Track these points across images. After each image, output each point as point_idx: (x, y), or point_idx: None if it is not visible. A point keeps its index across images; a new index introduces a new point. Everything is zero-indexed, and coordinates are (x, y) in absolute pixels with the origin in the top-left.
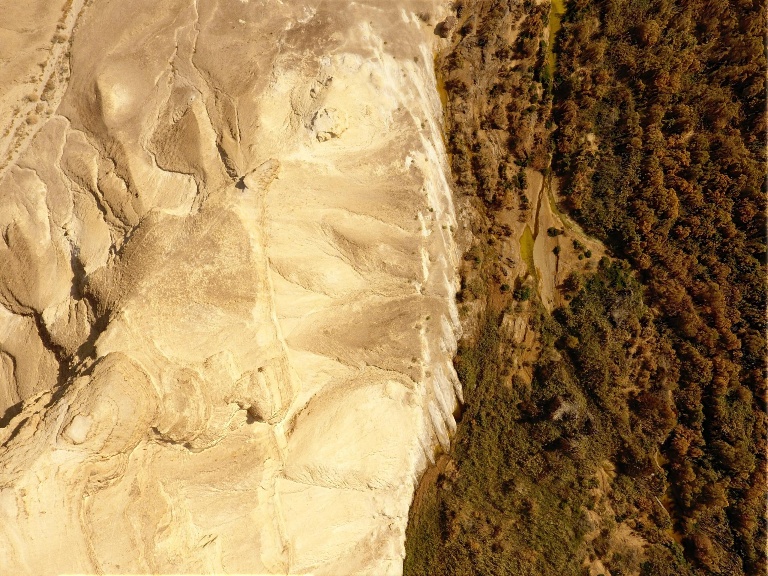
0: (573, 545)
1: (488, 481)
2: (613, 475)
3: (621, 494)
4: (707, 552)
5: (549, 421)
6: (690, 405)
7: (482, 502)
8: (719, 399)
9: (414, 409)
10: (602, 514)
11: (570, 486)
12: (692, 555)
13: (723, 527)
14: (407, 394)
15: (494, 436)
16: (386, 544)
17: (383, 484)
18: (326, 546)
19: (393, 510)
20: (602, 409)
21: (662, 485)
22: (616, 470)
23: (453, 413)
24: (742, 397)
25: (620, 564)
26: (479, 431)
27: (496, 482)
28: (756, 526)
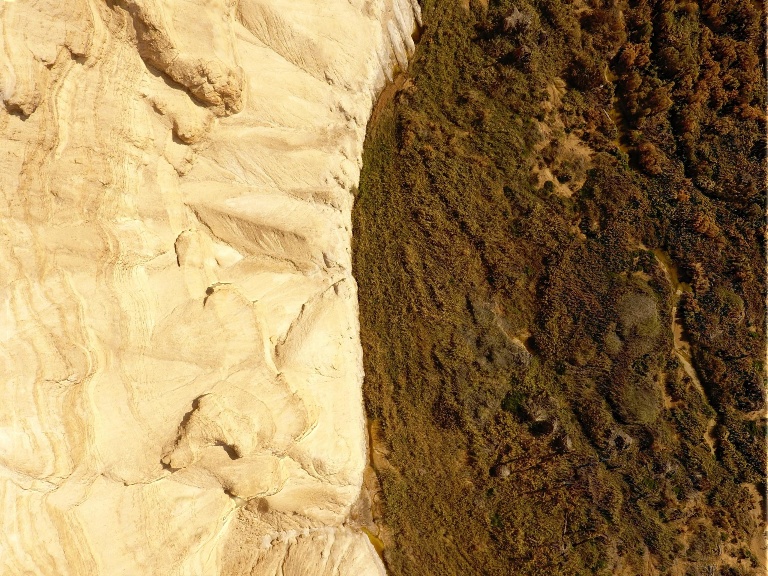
0: (523, 152)
1: (443, 94)
2: (564, 91)
3: (571, 105)
4: (650, 152)
5: (503, 36)
6: (639, 21)
7: (437, 113)
8: (667, 13)
9: (373, 21)
10: (552, 125)
11: (522, 99)
12: (637, 164)
13: (667, 134)
14: (366, 3)
15: (450, 52)
16: (342, 138)
17: (341, 82)
18: (281, 106)
19: (350, 107)
20: (555, 26)
21: (610, 95)
22: (567, 87)
23: (412, 35)
24: (689, 8)
25: (567, 168)
26: (436, 48)
27: (451, 97)
28: (698, 130)
